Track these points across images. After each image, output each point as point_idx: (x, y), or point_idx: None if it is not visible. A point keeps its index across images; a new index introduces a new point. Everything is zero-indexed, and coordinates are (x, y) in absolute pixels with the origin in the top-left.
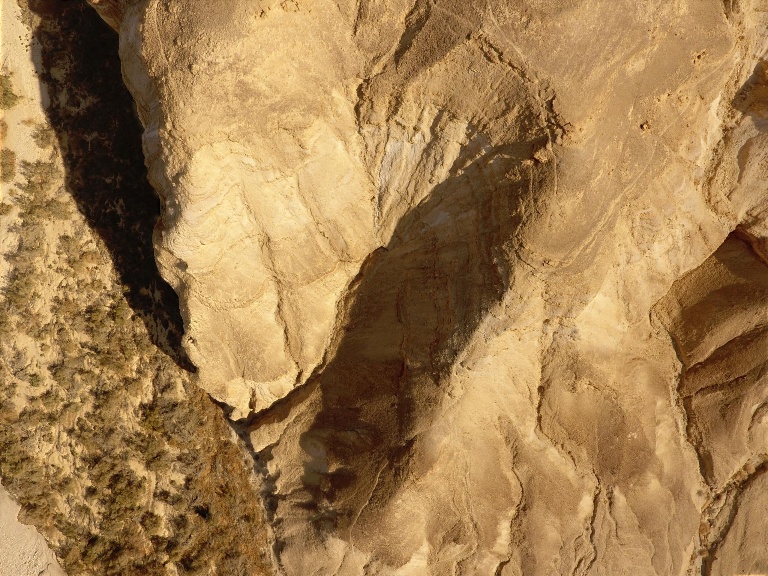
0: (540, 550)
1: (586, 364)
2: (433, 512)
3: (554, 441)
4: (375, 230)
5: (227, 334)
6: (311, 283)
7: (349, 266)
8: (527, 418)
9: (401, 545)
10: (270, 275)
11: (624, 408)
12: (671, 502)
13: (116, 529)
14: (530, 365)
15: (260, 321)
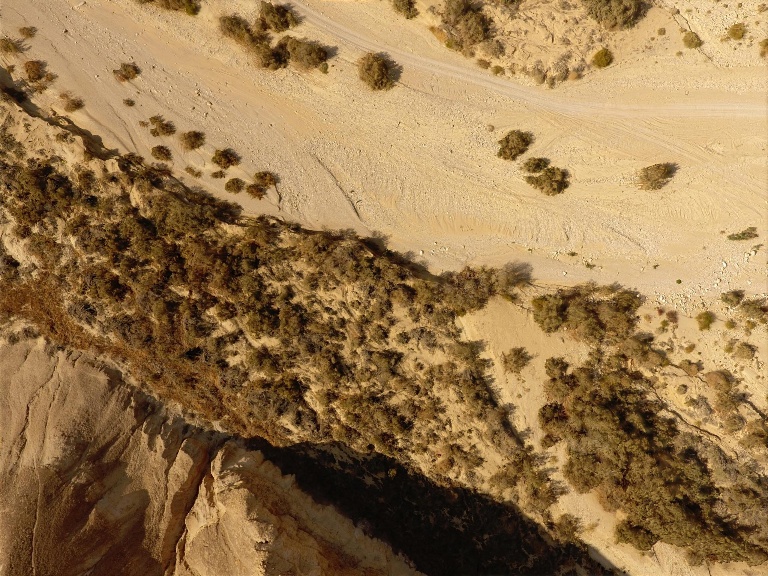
0: None
1: None
2: None
3: None
4: None
5: (238, 575)
6: None
7: None
8: None
9: None
10: None
11: None
12: None
13: (246, 287)
14: None
15: None
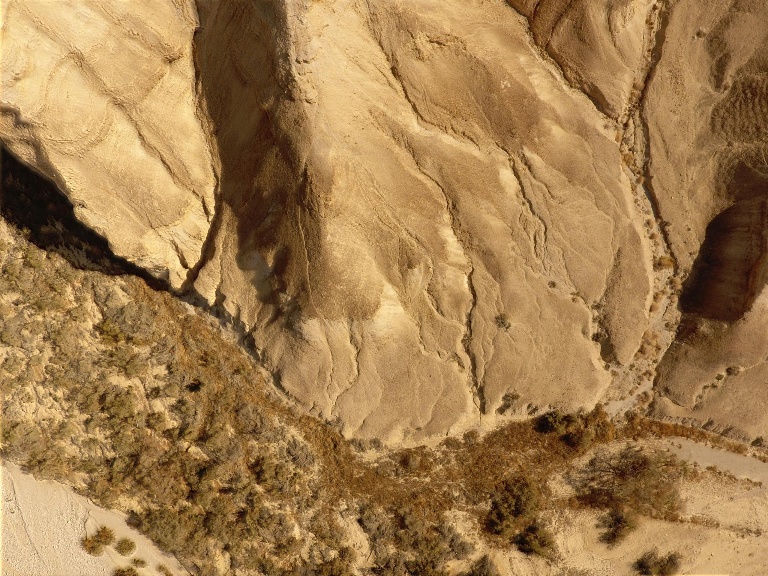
0: (491, 241)
1: (411, 15)
2: (371, 243)
3: (442, 127)
4: (180, 12)
5: (108, 182)
6: (152, 92)
7: (181, 64)
8: (400, 108)
9: (360, 288)
10: (109, 98)
11: (479, 57)
12: (584, 144)
13: (128, 442)
14: (365, 43)
15: (130, 155)
